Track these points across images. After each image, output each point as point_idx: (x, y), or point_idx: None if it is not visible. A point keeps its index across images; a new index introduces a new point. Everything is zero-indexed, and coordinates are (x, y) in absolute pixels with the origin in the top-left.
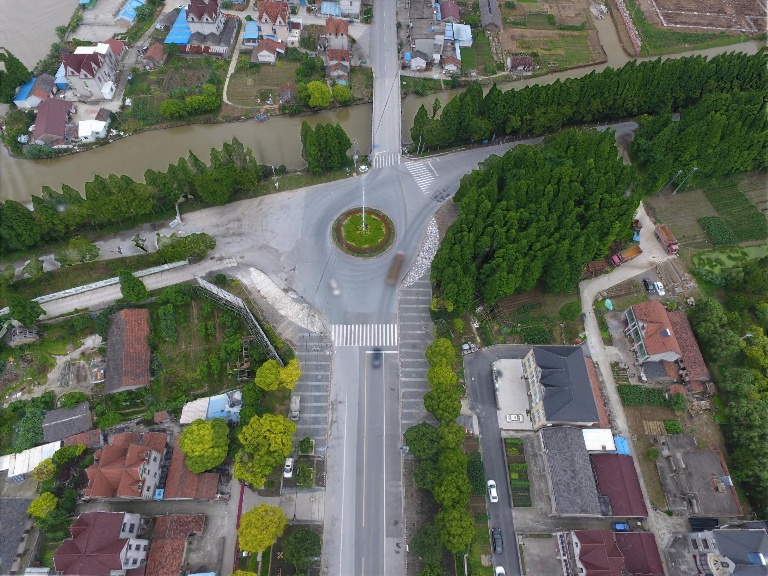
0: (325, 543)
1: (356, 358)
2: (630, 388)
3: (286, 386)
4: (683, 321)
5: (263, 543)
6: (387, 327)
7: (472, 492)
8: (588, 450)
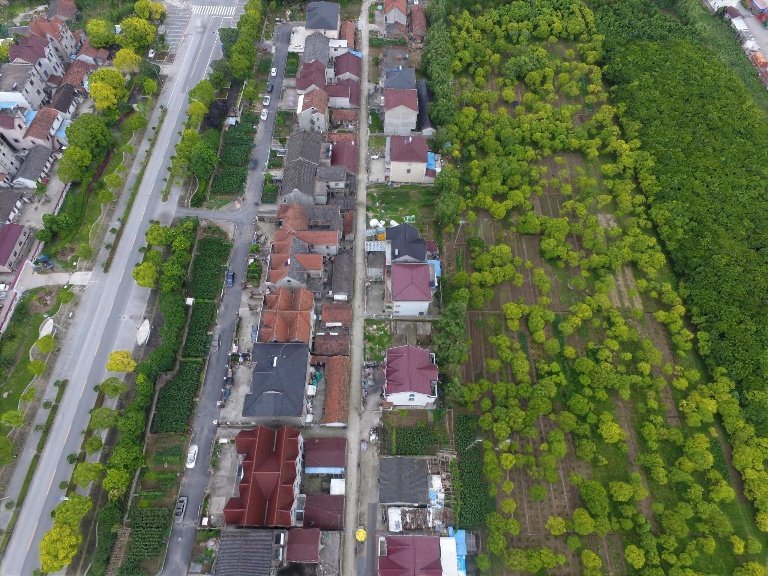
0: (167, 81)
1: (205, 19)
2: (376, 38)
3: (155, 16)
4: (419, 8)
5: (126, 62)
6: (229, 8)
7: (261, 70)
8: (330, 46)
